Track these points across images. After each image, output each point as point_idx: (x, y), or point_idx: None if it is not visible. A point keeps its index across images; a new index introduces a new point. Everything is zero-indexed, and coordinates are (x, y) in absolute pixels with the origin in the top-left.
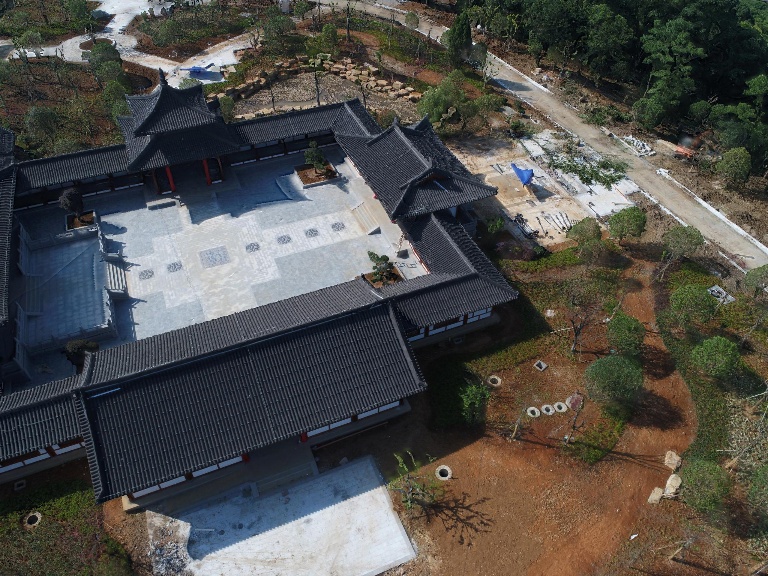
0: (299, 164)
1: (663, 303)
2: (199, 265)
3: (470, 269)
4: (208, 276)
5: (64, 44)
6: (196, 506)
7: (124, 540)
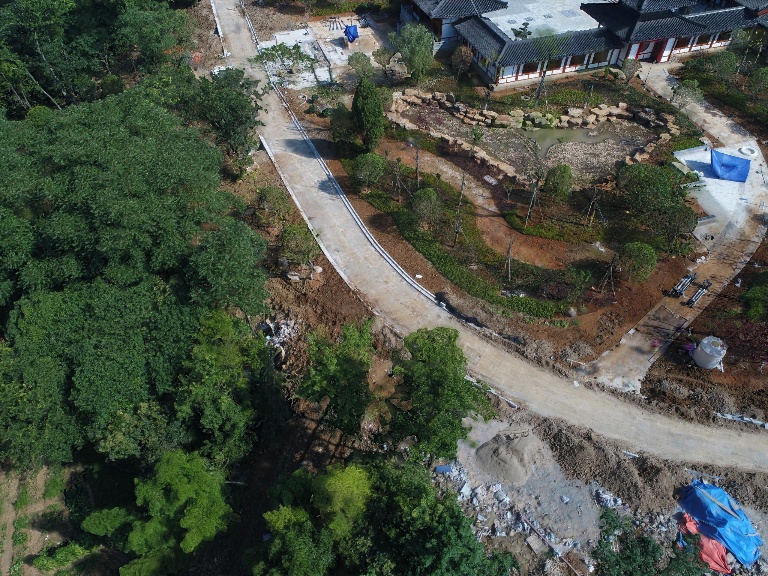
0: None
1: None
2: (577, 10)
3: None
4: (568, 6)
5: None
6: None
7: None
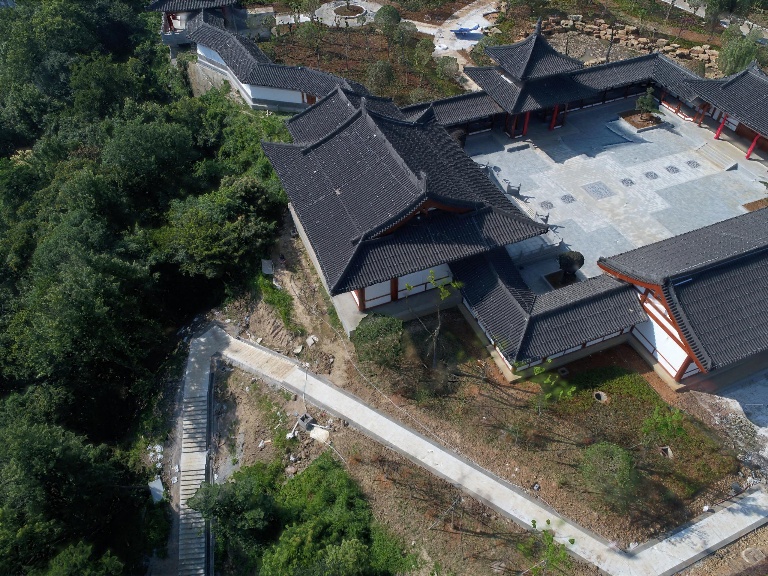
0: (620, 111)
1: None
2: (589, 197)
3: None
4: (604, 206)
5: (317, 11)
6: (732, 387)
7: (690, 412)
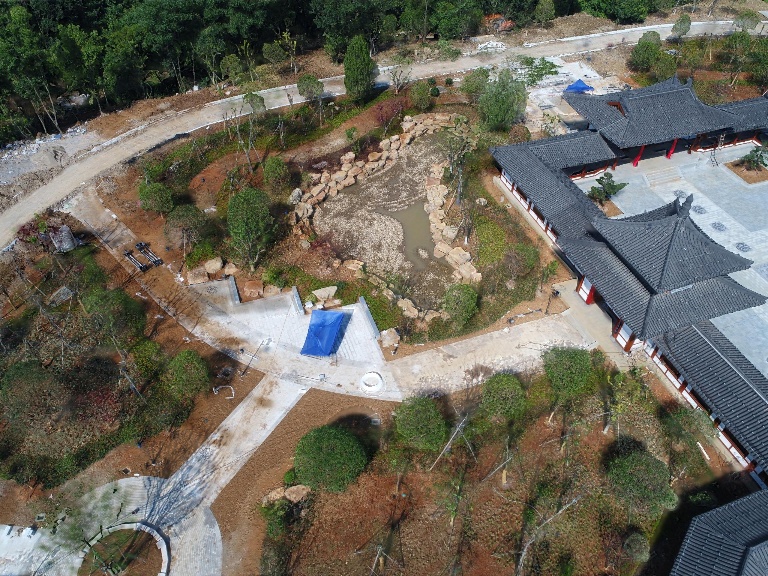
0: None
1: (701, 67)
2: None
3: (766, 102)
4: None
5: None
6: None
7: None
